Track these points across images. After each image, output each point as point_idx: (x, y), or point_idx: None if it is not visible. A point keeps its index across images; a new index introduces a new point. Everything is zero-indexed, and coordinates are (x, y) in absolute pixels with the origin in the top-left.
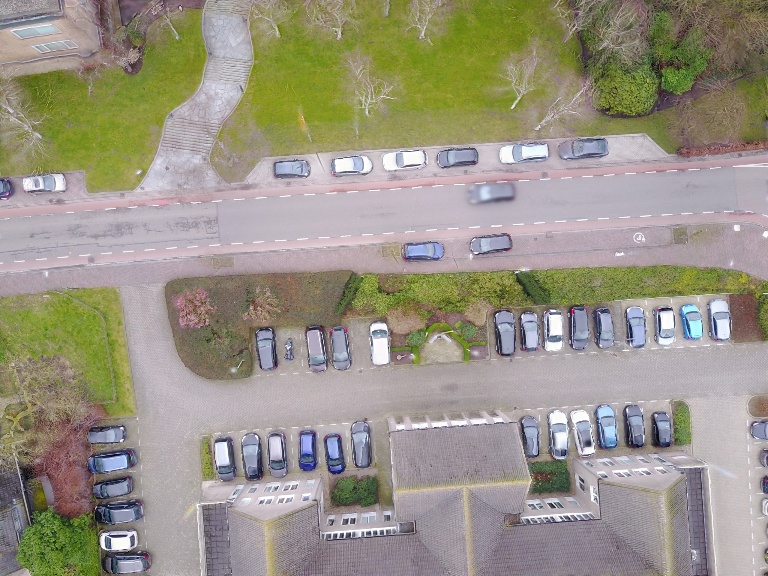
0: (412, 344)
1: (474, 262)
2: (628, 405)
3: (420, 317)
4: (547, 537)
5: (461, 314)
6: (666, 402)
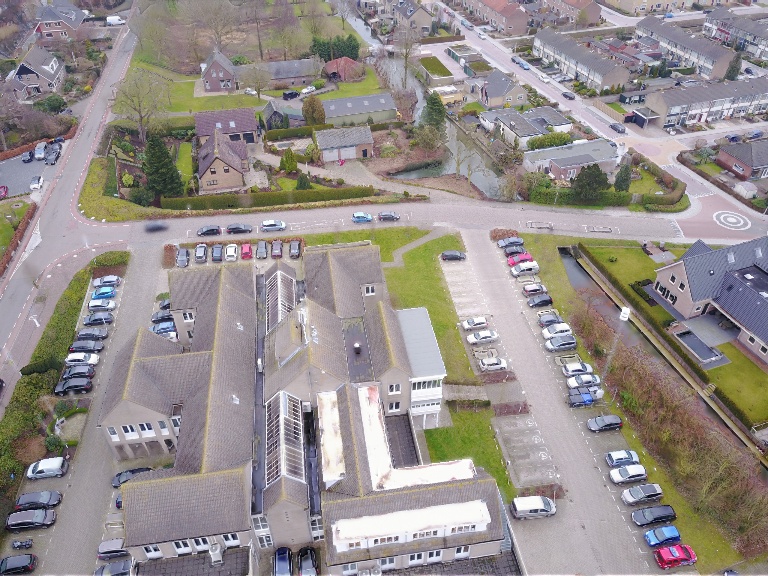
0: (55, 443)
1: (3, 403)
2: (151, 321)
3: (33, 438)
4: (198, 329)
5: (47, 416)
6: (155, 304)
